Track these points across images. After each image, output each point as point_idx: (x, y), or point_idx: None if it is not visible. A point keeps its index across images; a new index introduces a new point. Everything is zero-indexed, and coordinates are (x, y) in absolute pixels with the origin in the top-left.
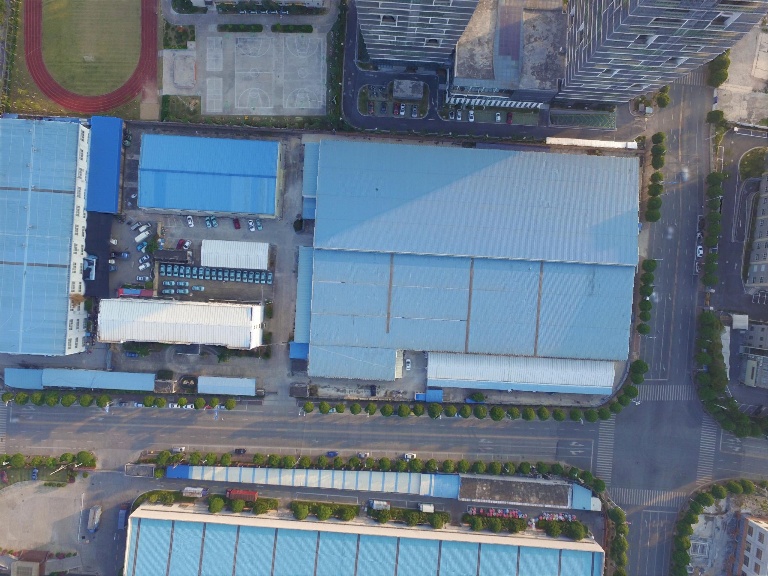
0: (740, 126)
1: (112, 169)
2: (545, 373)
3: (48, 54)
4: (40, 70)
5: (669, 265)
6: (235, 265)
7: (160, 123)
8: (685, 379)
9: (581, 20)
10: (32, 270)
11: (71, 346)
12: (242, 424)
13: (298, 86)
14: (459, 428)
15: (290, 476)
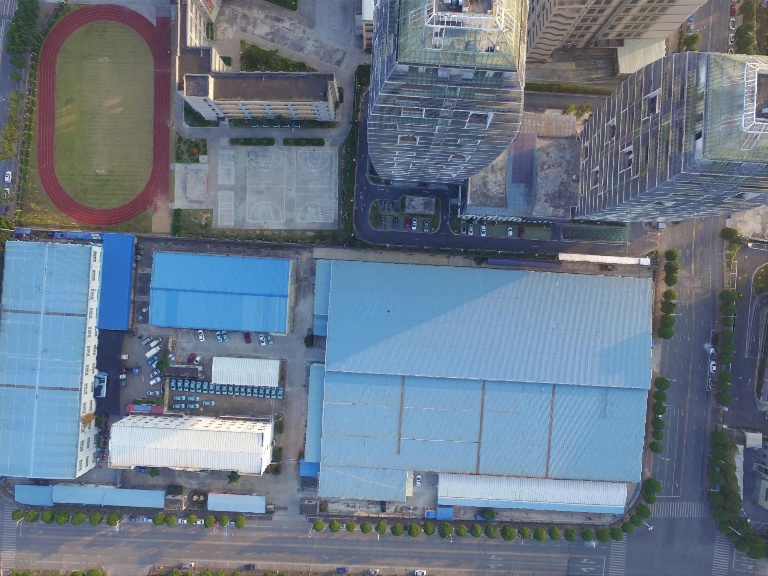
0: (754, 241)
1: (124, 286)
2: (557, 492)
3: (61, 167)
4: (53, 183)
5: (682, 380)
6: (246, 383)
7: (172, 238)
8: (698, 496)
9: (596, 162)
10: (44, 394)
11: (82, 467)
12: (252, 539)
13: (310, 200)
14: (469, 544)
15: None
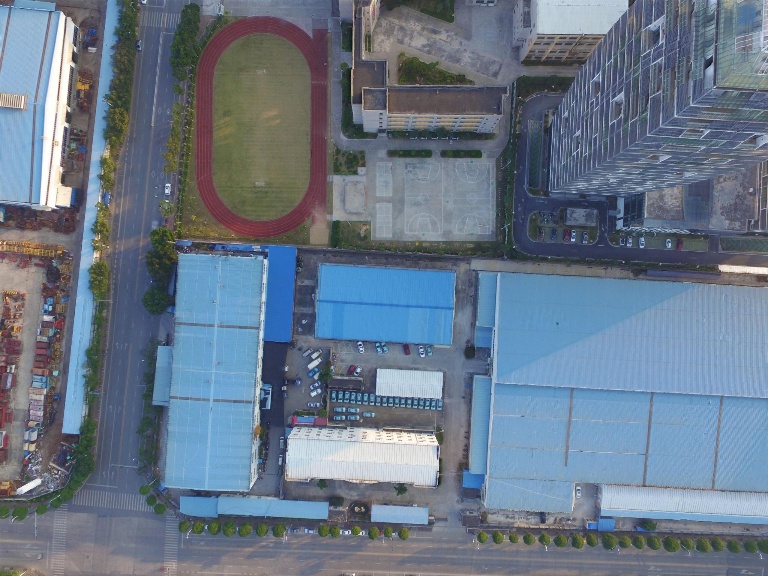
0: None
1: (288, 298)
2: (719, 504)
3: (219, 179)
4: (211, 195)
5: None
6: (410, 394)
7: (332, 250)
8: None
9: None
10: (218, 406)
11: (252, 479)
12: (412, 550)
13: (467, 211)
14: (628, 555)
15: None
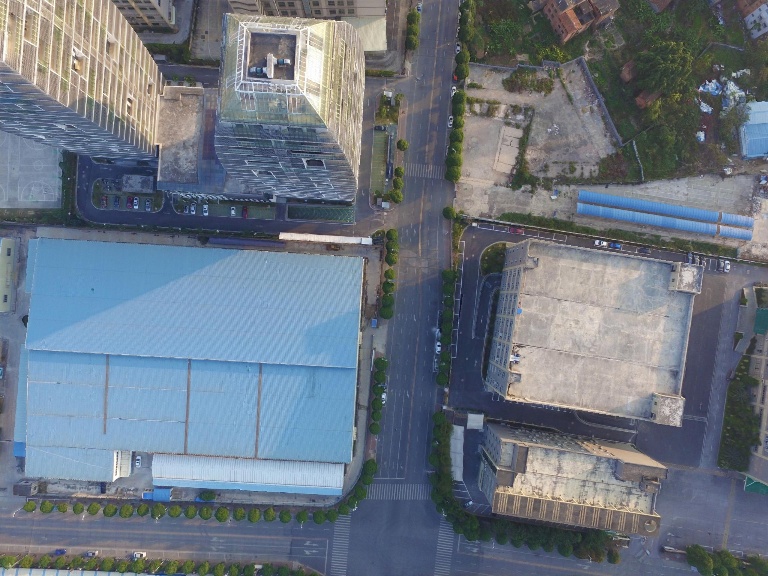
0: (481, 221)
1: None
2: (272, 473)
3: None
4: None
5: (408, 361)
6: None
7: None
8: (423, 478)
9: None
10: None
11: None
12: None
13: (33, 178)
14: (191, 526)
15: (13, 575)
